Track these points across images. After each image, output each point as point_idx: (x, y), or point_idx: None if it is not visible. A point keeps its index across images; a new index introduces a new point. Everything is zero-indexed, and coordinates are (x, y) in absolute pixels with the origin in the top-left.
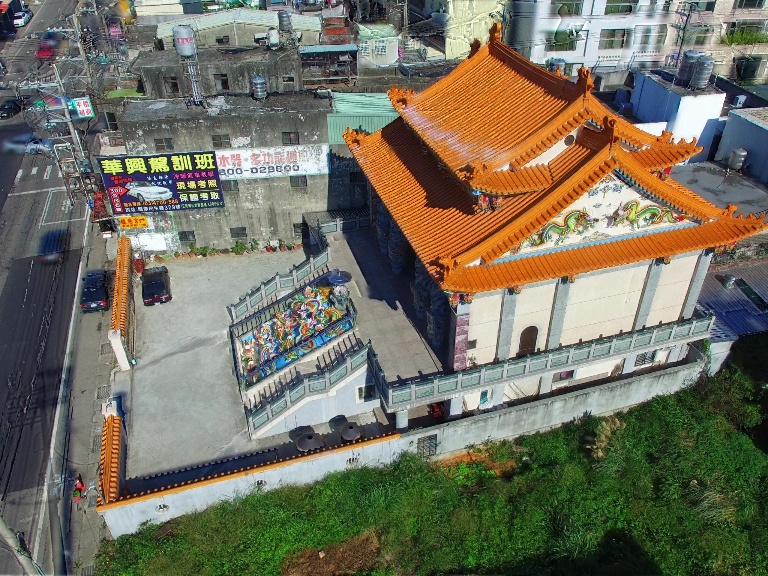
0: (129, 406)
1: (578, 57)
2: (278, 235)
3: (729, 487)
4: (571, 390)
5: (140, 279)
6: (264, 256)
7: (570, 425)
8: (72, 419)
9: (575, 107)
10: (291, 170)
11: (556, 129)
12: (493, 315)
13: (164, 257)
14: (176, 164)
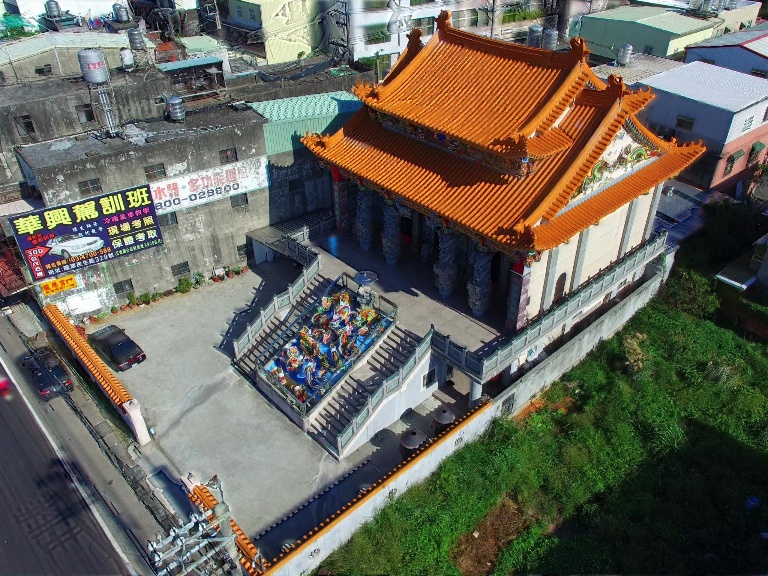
0: None
1: (394, 47)
2: (222, 262)
3: None
4: (581, 324)
5: (90, 346)
6: (215, 287)
7: (595, 353)
8: (120, 514)
9: (575, 72)
10: (231, 190)
11: (564, 94)
12: (542, 270)
13: (101, 316)
14: (106, 207)
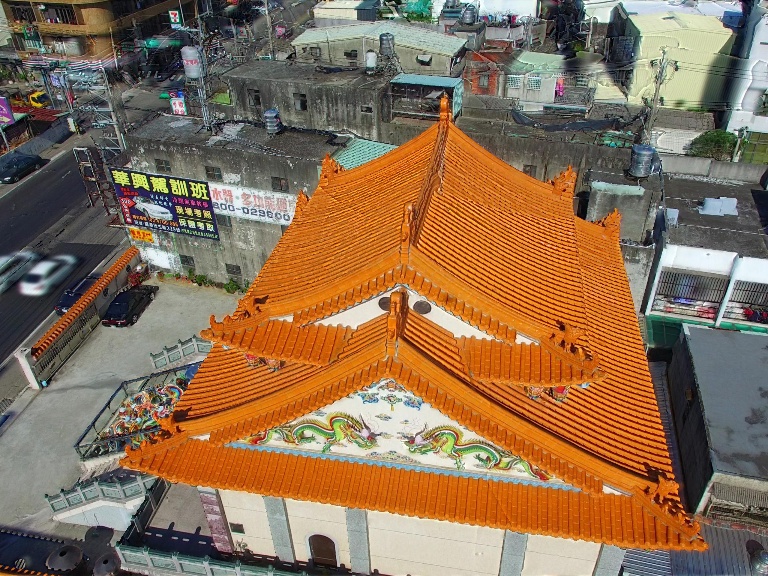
0: (4, 430)
1: None
2: None
3: None
4: None
5: None
6: None
7: None
8: None
9: (388, 260)
10: (282, 218)
11: (360, 284)
12: (258, 504)
13: (165, 276)
14: (174, 187)
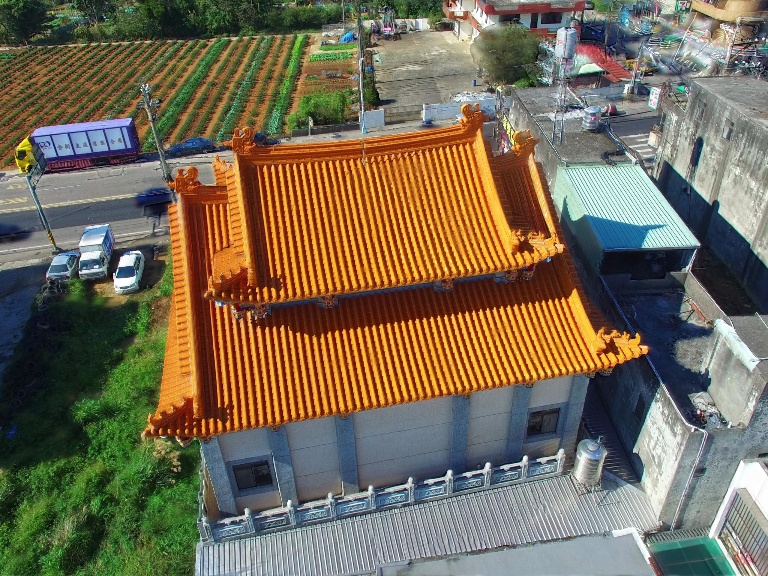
0: None
1: None
2: None
3: (82, 569)
4: None
5: None
6: None
7: None
8: None
9: None
10: None
11: None
12: None
13: None
14: None
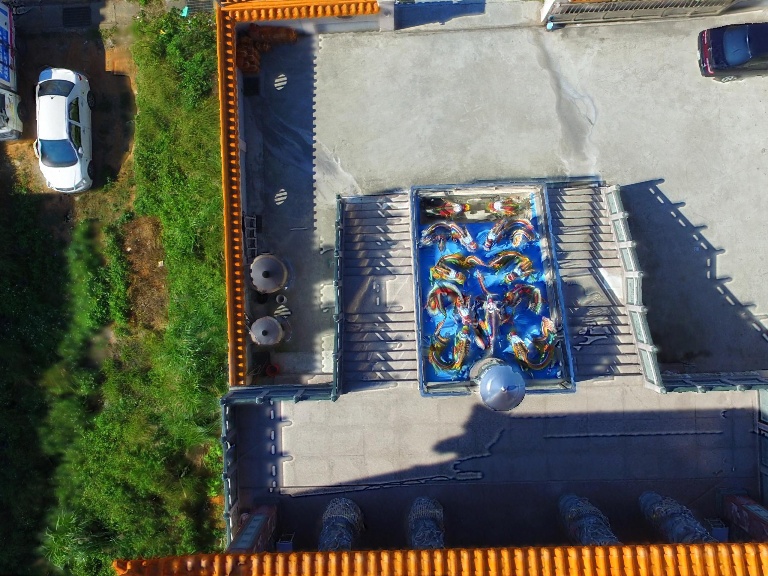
0: (457, 27)
1: None
2: None
3: None
4: None
5: None
6: None
7: None
8: None
9: None
10: None
11: None
12: None
13: None
14: None
